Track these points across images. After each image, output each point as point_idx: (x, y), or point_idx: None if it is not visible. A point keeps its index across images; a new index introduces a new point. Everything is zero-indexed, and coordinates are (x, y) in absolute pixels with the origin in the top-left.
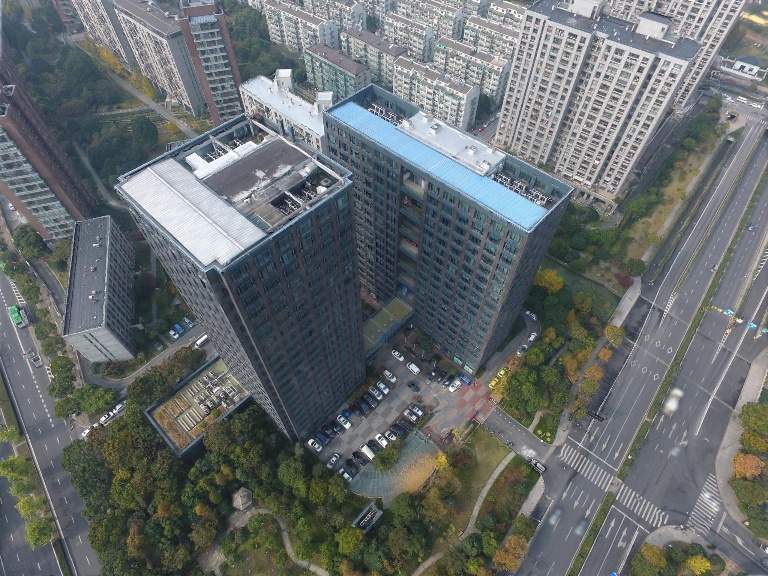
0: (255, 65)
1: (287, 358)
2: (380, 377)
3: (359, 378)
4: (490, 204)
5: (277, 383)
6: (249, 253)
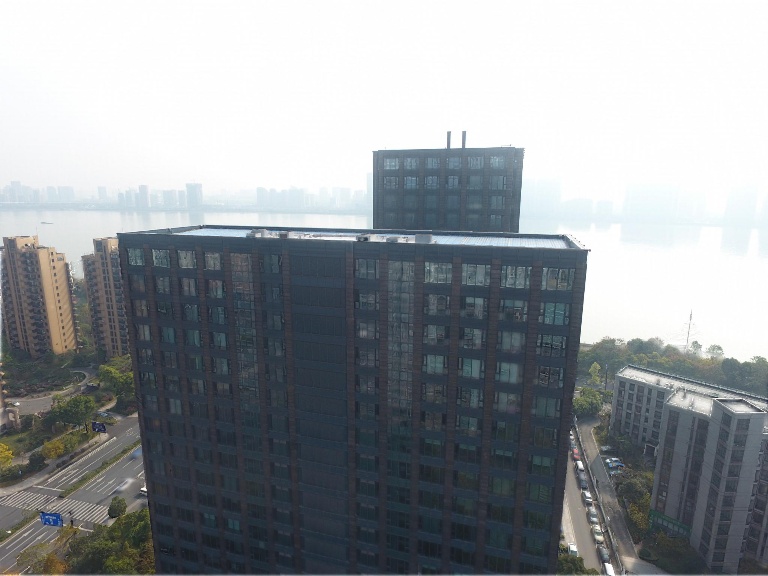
0: None
1: None
2: None
3: None
4: (249, 230)
5: None
6: None
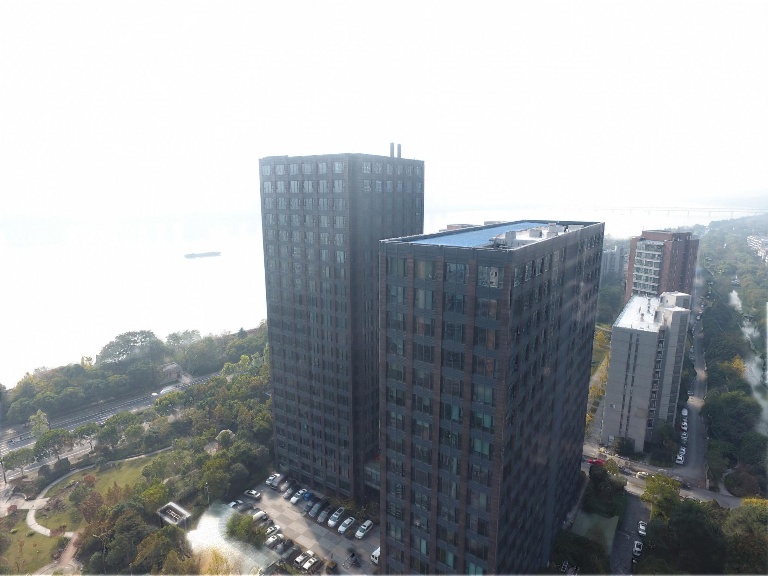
0: (741, 339)
1: (280, 303)
2: (361, 519)
3: (345, 480)
4: None
5: (270, 324)
6: (273, 157)
